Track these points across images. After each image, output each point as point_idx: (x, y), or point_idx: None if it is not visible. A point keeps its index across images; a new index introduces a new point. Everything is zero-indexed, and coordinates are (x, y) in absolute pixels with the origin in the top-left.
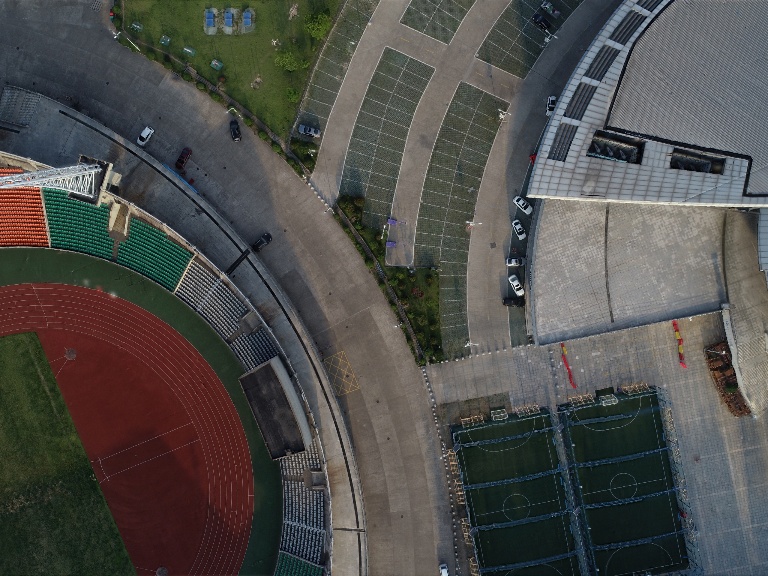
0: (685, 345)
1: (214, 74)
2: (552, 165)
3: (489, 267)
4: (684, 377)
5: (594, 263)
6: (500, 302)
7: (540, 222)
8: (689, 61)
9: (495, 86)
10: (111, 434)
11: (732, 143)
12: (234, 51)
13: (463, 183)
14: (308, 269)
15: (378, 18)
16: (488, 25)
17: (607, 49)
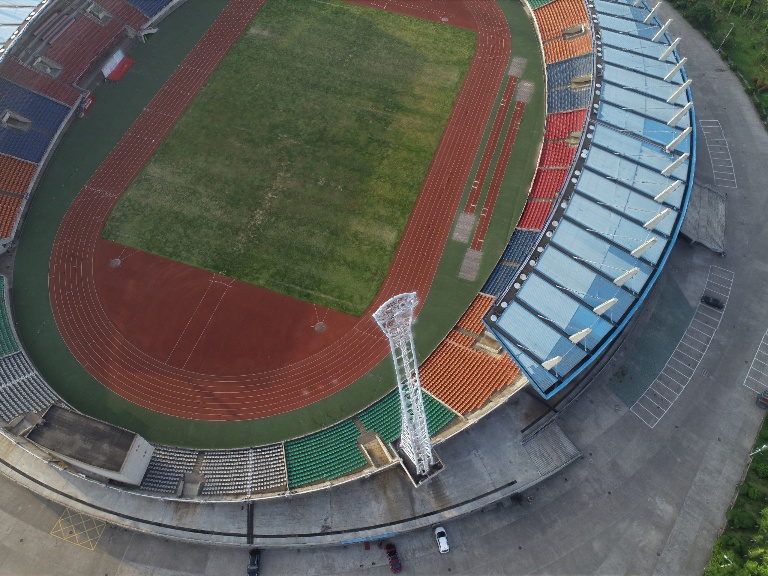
0: None
1: None
2: None
3: None
4: None
5: None
6: None
7: None
8: None
9: None
10: (238, 307)
11: None
12: None
13: None
14: None
15: None
16: None
17: None
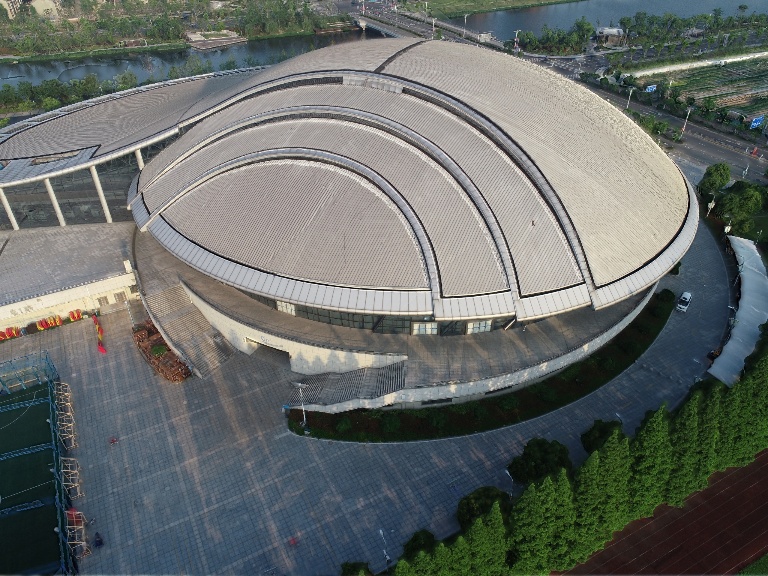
0: (108, 335)
1: None
2: None
3: None
4: (103, 362)
5: None
6: None
7: None
8: None
9: None
10: None
11: None
12: None
13: None
14: None
15: None
16: None
17: None
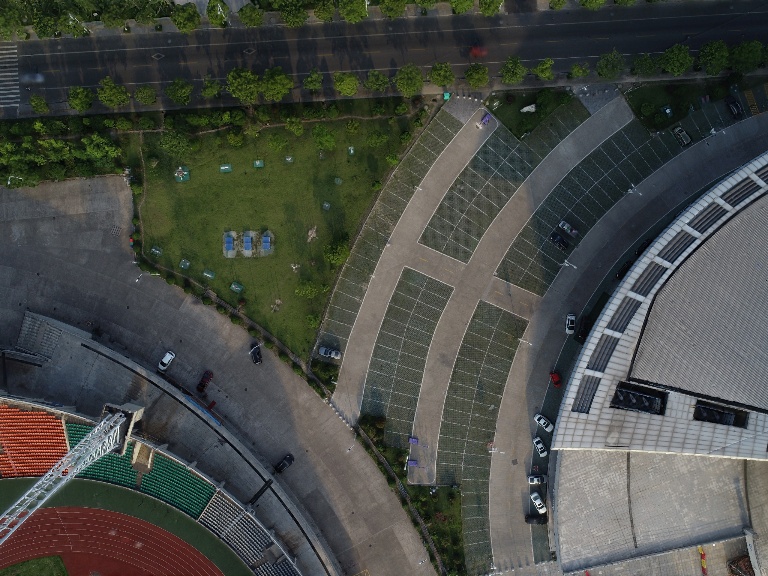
0: (708, 559)
1: (234, 297)
2: (576, 418)
3: (511, 484)
4: None
5: (617, 489)
6: (522, 519)
7: (562, 451)
8: (711, 313)
9: (514, 304)
10: None
11: (755, 397)
12: (254, 274)
13: (484, 401)
14: (330, 489)
15: (396, 238)
16: (506, 244)
17: (629, 300)
